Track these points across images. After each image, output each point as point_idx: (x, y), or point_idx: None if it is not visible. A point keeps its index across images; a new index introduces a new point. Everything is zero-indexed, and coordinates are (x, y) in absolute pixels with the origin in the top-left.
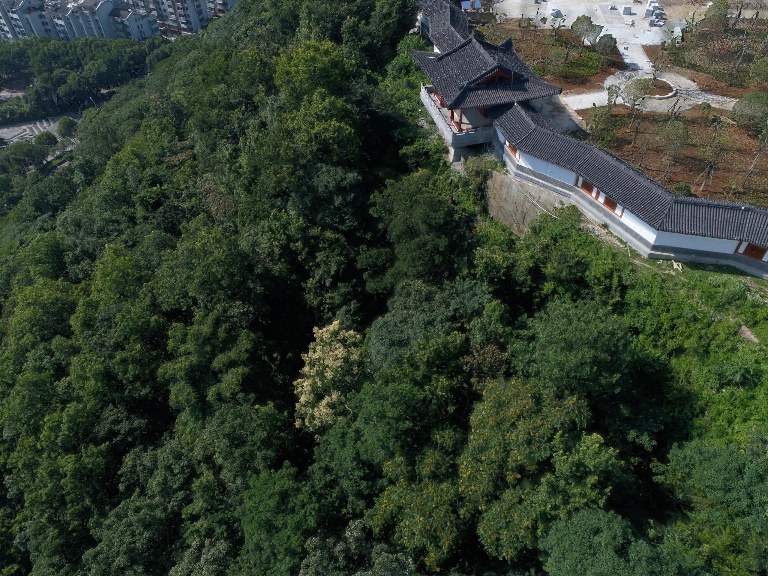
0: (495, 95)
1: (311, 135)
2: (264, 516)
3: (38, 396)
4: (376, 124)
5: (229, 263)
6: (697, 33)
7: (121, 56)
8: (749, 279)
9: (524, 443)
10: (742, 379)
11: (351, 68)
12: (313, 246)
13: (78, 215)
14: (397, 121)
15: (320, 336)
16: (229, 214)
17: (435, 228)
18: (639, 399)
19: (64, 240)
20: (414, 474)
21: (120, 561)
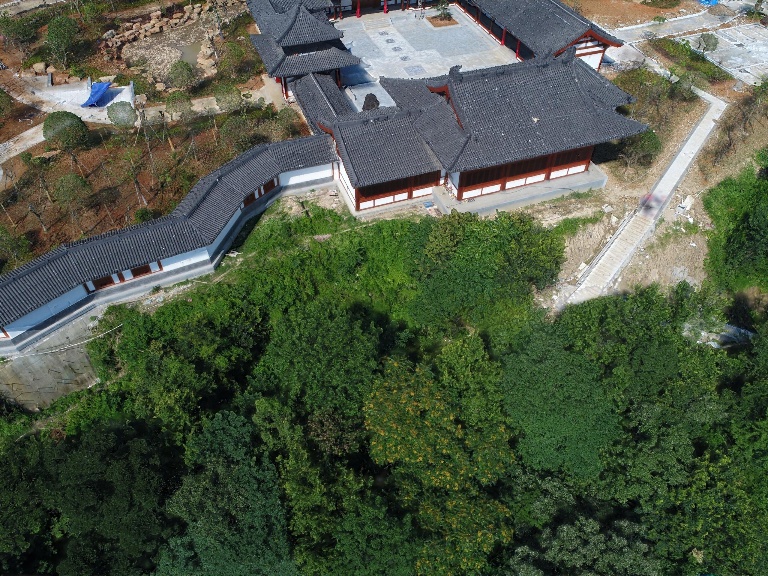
0: None
1: None
2: None
3: None
4: None
5: None
6: None
7: None
8: (265, 216)
9: None
10: None
11: None
12: None
13: None
14: None
15: None
16: None
17: (107, 451)
18: None
19: None
20: None
21: None
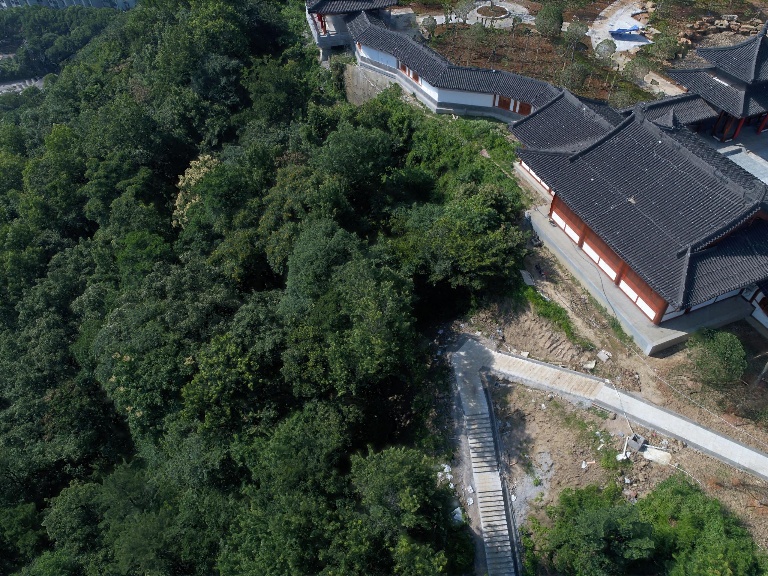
0: (348, 5)
1: (203, 30)
2: (131, 254)
3: None
4: (266, 33)
5: (137, 122)
6: None
7: (105, 23)
8: (502, 125)
9: (290, 189)
10: (471, 179)
11: None
12: (204, 115)
13: (37, 112)
14: (281, 30)
15: (194, 164)
16: (148, 99)
17: (280, 88)
18: None
19: (25, 131)
20: (232, 227)
21: (40, 305)
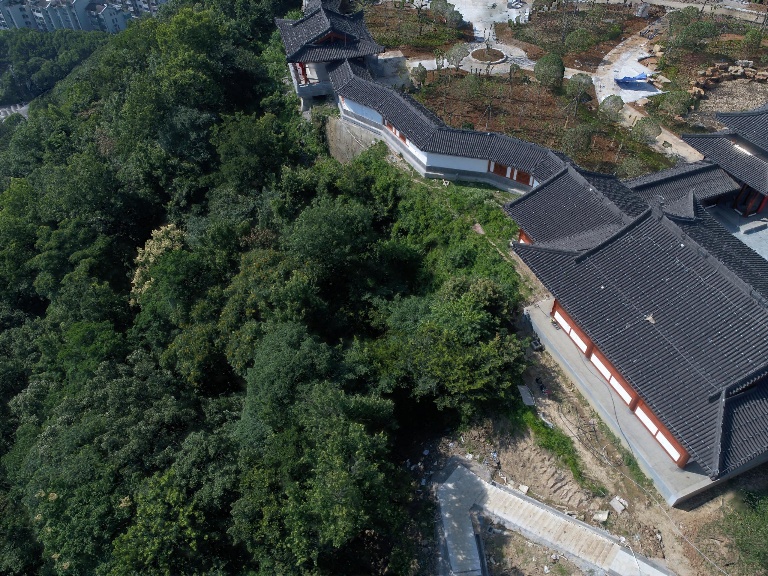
0: (330, 53)
1: (170, 81)
2: (74, 350)
3: None
4: (243, 80)
5: (96, 183)
6: (545, 14)
7: (93, 47)
8: (498, 192)
9: (253, 283)
10: (463, 260)
11: (224, 33)
12: (172, 174)
13: None
14: (259, 77)
15: (155, 235)
16: (114, 152)
17: (252, 150)
18: (394, 280)
19: None
20: (190, 319)
21: None
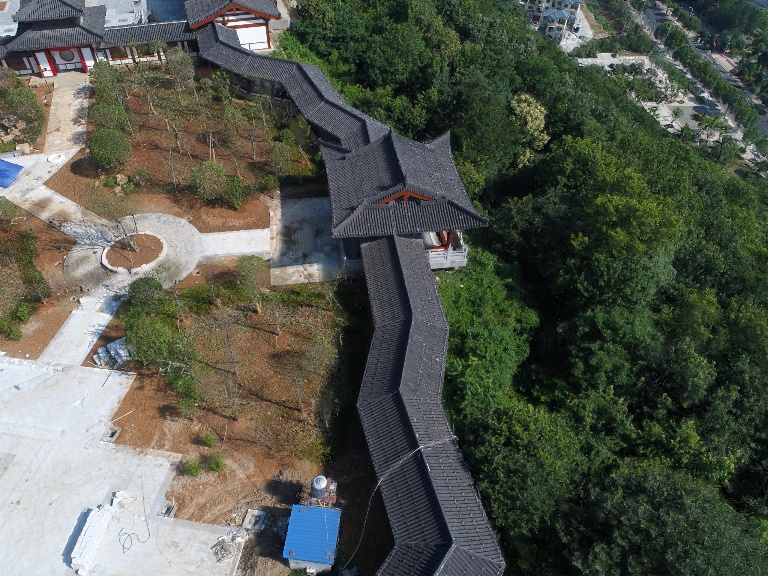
0: None
1: None
2: None
3: (731, 187)
4: None
5: None
6: None
7: None
8: None
9: None
10: None
11: None
12: None
13: None
14: None
15: None
16: None
17: None
18: None
19: None
20: None
21: None
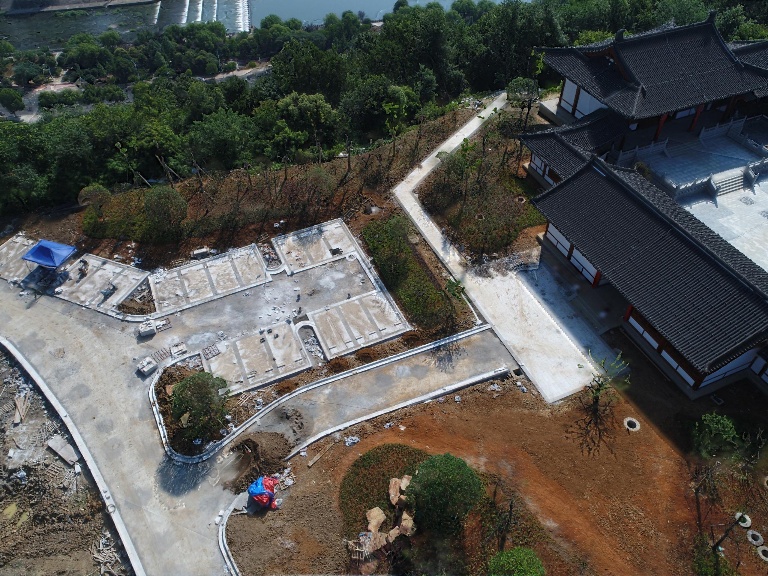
0: None
1: None
2: None
3: None
4: None
5: None
6: None
7: None
8: None
9: None
10: None
11: None
12: None
13: None
14: None
15: None
16: None
17: None
18: None
19: None
20: None
21: None
